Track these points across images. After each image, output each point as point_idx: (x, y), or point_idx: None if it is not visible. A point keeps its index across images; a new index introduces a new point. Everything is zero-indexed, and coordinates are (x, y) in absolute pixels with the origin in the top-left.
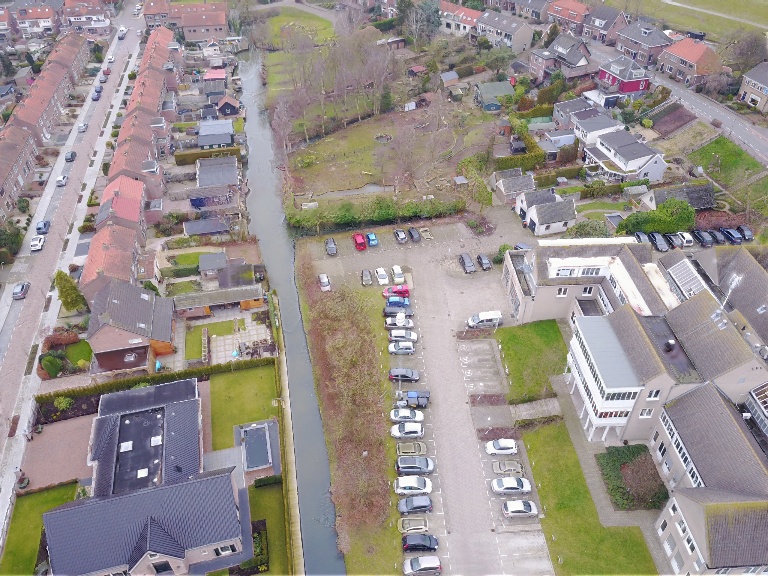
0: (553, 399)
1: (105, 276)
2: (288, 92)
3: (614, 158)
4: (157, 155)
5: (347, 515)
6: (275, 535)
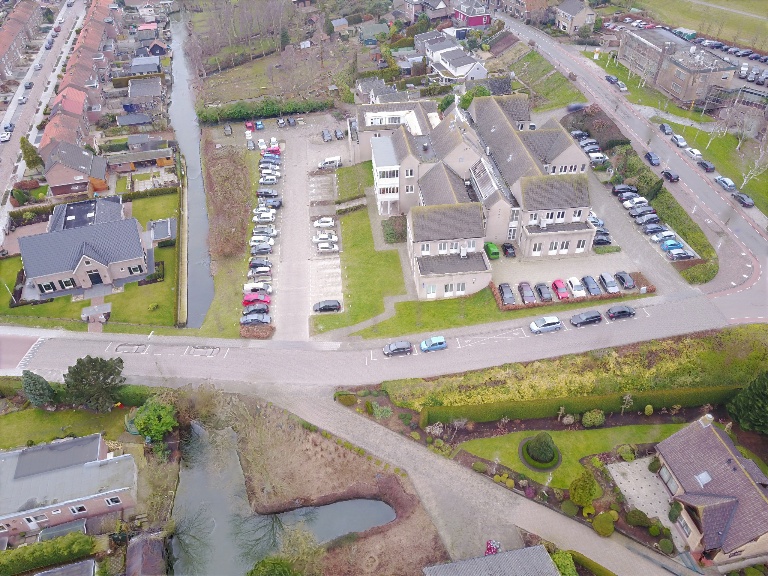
0: (363, 198)
1: (56, 141)
2: None
3: (449, 68)
4: (99, 82)
5: (214, 249)
6: (169, 267)
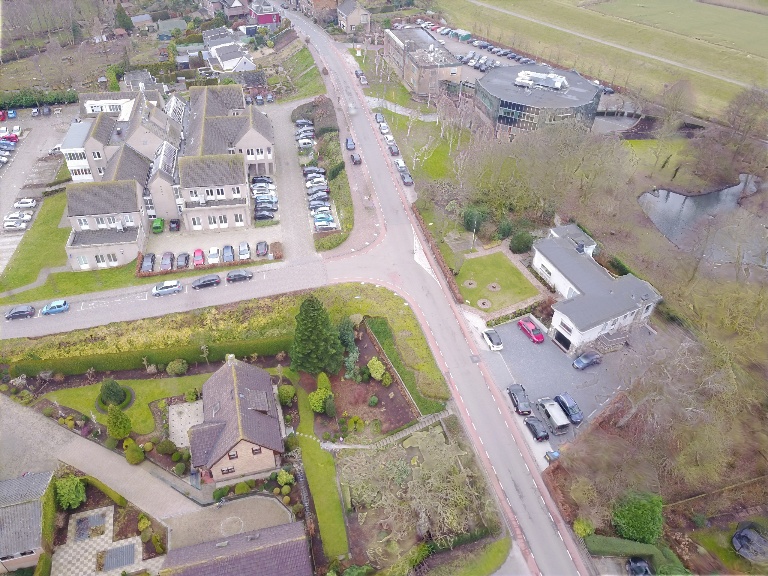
0: None
1: None
2: (7, 32)
3: None
4: None
5: None
6: None
